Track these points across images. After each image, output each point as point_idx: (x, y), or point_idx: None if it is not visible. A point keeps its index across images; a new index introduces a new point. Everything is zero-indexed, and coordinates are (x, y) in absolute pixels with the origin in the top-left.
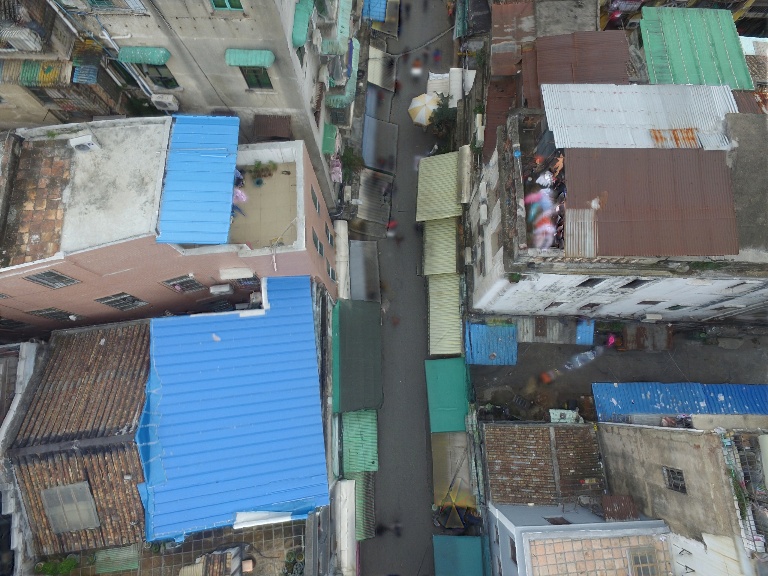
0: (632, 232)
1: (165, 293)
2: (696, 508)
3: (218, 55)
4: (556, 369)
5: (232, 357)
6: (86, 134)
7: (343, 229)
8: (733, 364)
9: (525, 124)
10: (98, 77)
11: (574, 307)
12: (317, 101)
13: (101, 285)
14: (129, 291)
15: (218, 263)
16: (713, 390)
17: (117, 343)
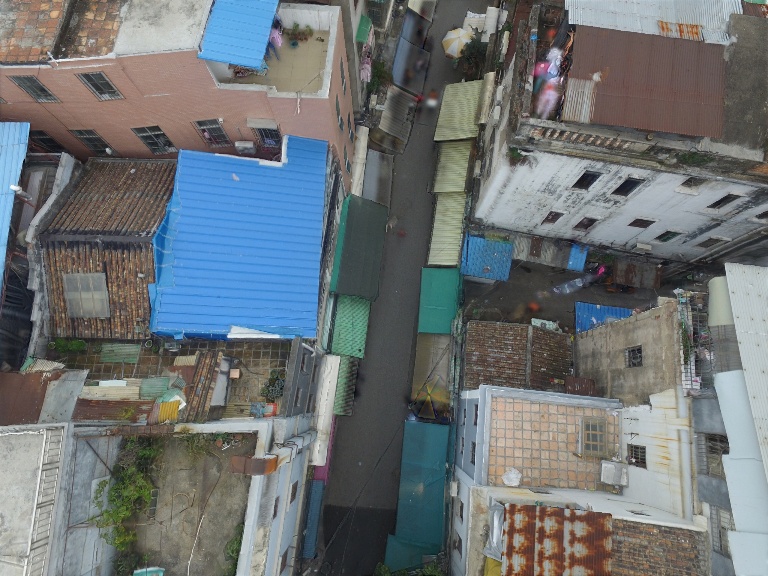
0: (626, 106)
1: (194, 141)
2: (648, 375)
3: None
4: None
5: (247, 197)
6: None
7: (364, 135)
8: None
9: (546, 18)
10: None
11: (569, 224)
12: None
13: (141, 109)
14: (163, 126)
15: (247, 108)
16: None
17: (146, 173)
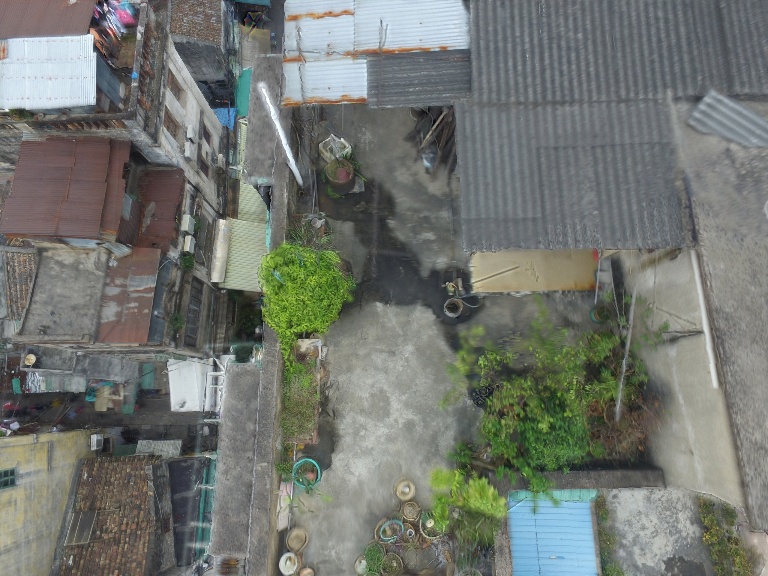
0: None
1: None
2: None
3: None
4: None
5: None
6: None
7: None
8: None
9: None
10: None
11: None
12: None
13: None
14: None
15: None
16: None
17: None
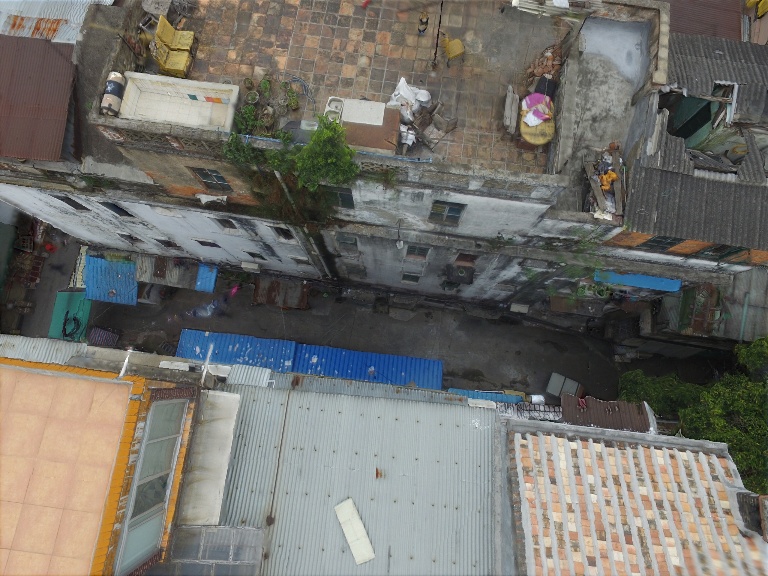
0: None
1: None
2: None
3: None
4: None
5: None
6: None
7: None
8: (397, 335)
9: None
10: None
11: (157, 244)
12: None
13: None
14: None
15: None
16: (310, 351)
17: None
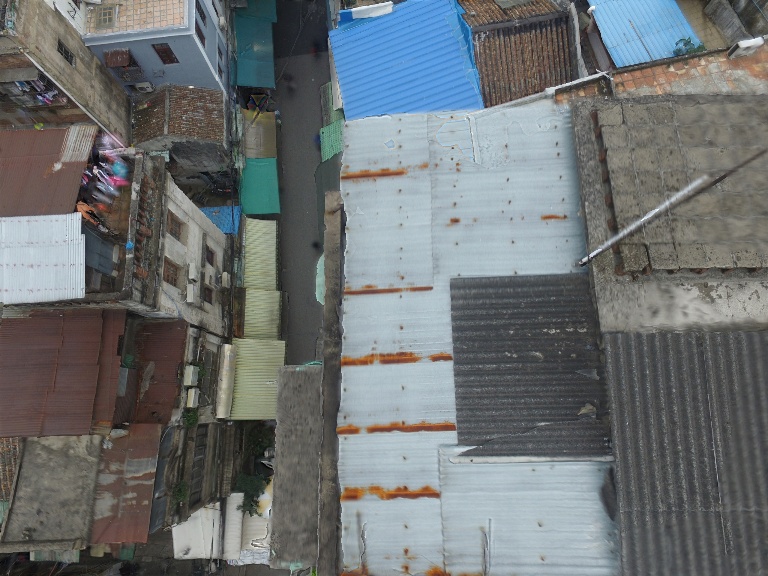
0: (32, 147)
1: None
2: (54, 24)
3: None
4: None
5: (415, 110)
6: None
7: None
8: None
9: None
10: None
11: None
12: None
13: None
14: None
15: None
16: None
17: None
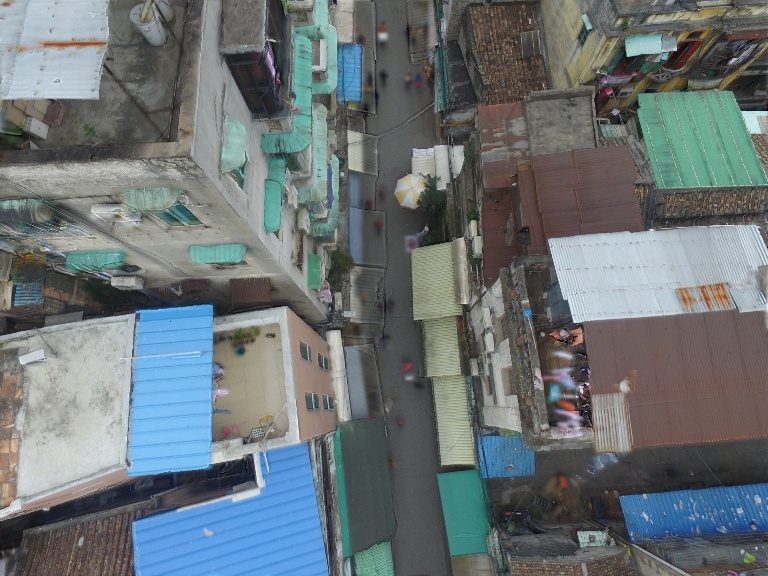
0: (669, 416)
1: None
2: None
3: (181, 250)
4: (578, 475)
5: (228, 553)
6: (38, 343)
7: (337, 339)
8: (761, 441)
9: (531, 267)
10: (46, 282)
11: None
12: (298, 254)
13: (72, 495)
14: (106, 485)
15: None
16: (748, 491)
17: (97, 543)
